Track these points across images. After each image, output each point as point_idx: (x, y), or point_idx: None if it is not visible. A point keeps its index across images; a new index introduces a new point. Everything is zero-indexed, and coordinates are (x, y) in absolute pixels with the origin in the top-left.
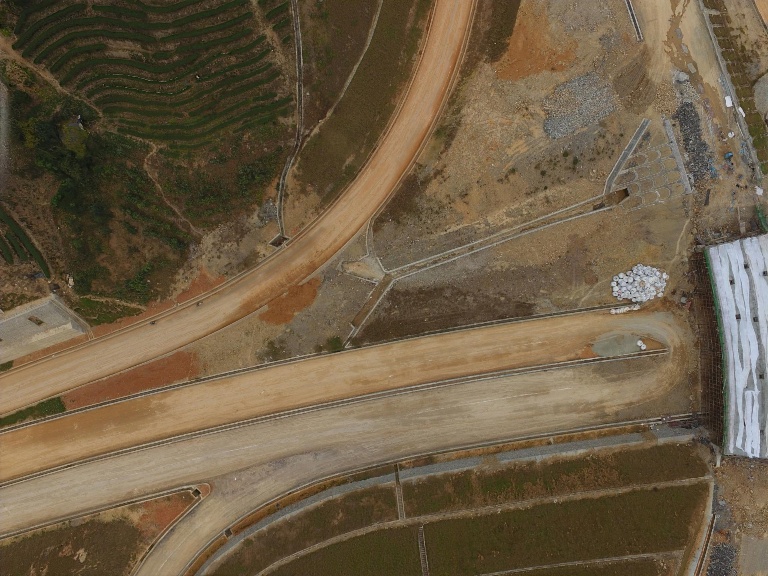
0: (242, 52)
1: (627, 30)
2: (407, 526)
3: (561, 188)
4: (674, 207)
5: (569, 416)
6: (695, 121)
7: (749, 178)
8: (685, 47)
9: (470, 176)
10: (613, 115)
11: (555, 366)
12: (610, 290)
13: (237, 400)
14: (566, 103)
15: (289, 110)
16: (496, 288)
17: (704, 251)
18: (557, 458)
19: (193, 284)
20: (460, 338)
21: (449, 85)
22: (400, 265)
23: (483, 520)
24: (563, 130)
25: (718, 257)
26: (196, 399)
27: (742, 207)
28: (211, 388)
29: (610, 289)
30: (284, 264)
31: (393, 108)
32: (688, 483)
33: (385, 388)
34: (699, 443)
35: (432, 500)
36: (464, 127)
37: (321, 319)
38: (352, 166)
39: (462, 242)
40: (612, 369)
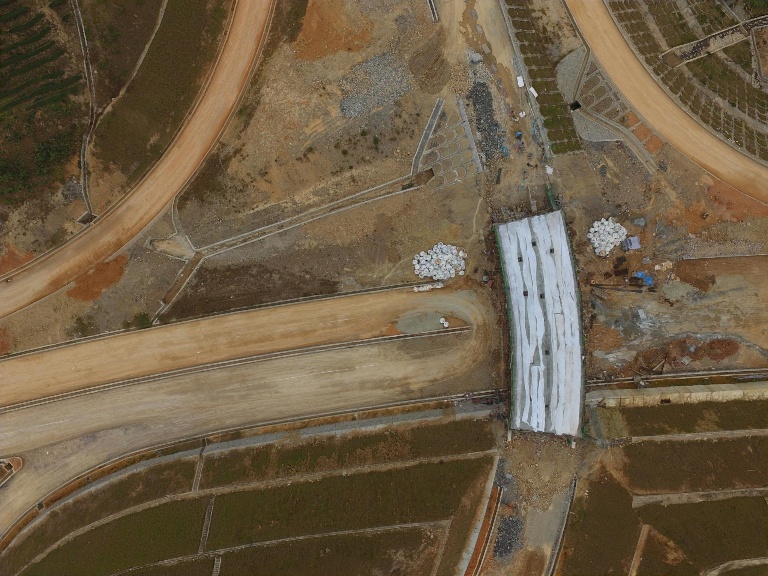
0: (22, 30)
1: (423, 11)
2: (199, 498)
3: (367, 168)
4: (469, 186)
5: (374, 392)
6: (487, 101)
7: (539, 157)
8: (480, 28)
9: (268, 155)
10: (408, 95)
11: (359, 343)
12: (412, 268)
13: (48, 375)
14: (362, 83)
15: (79, 88)
16: (301, 266)
17: (494, 229)
18: (356, 433)
19: (3, 261)
20: (267, 315)
21: (252, 65)
22: (209, 243)
23: (272, 492)
24: (358, 109)
25: (507, 235)
26: (8, 374)
27: (533, 186)
28: (23, 363)
29: (412, 267)
30: (92, 241)
31: (198, 88)
32: (474, 456)
33: (193, 364)
34: (495, 418)
35: (227, 473)
36: (263, 106)
37: (128, 296)
38: (158, 145)
39: (270, 221)
40: (416, 346)
